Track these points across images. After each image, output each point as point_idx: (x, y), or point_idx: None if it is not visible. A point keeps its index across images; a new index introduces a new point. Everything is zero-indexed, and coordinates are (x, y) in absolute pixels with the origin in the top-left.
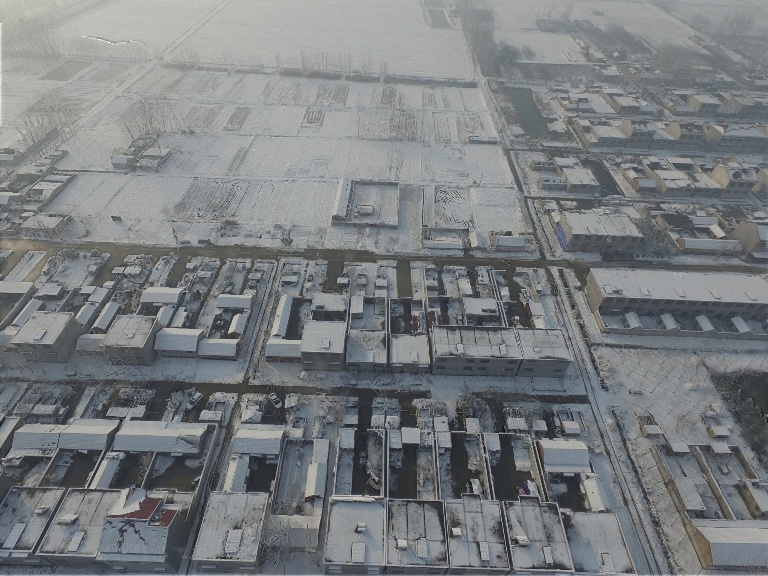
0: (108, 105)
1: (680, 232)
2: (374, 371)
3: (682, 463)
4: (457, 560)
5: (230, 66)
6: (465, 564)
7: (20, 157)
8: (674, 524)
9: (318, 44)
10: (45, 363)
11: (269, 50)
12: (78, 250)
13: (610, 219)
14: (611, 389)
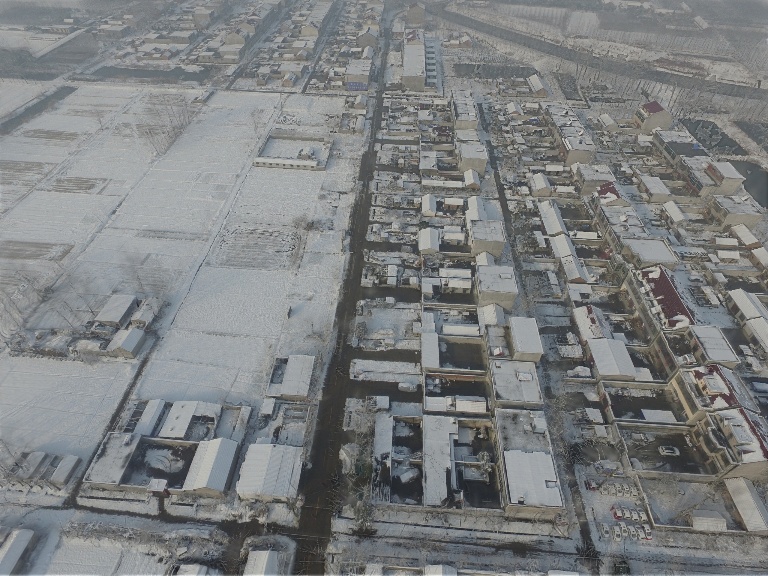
0: None
1: None
2: None
3: None
4: None
5: None
6: None
7: None
8: None
9: None
10: None
11: None
12: (351, 330)
13: (354, 64)
14: None
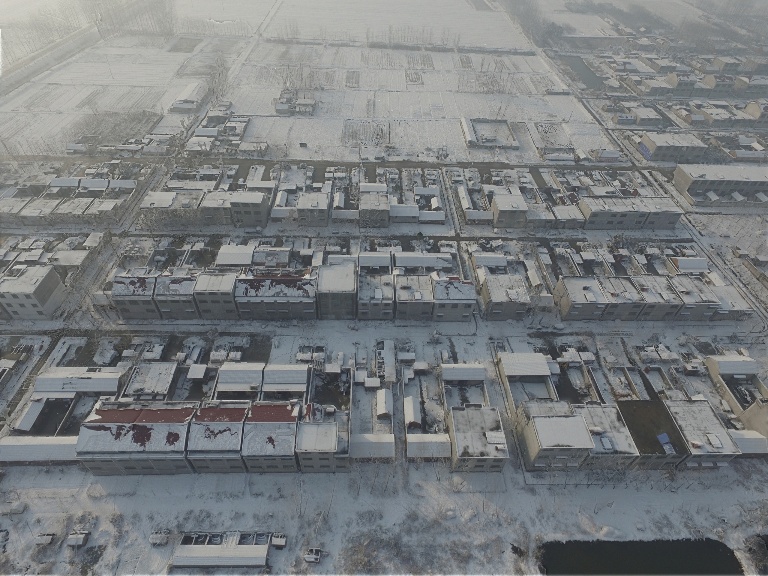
0: (240, 70)
1: (730, 148)
2: (545, 227)
3: (765, 269)
4: (650, 300)
5: (323, 41)
6: (656, 302)
7: (199, 106)
8: (767, 296)
9: (387, 24)
10: (312, 227)
11: (348, 28)
12: None
13: (681, 137)
14: (707, 235)
